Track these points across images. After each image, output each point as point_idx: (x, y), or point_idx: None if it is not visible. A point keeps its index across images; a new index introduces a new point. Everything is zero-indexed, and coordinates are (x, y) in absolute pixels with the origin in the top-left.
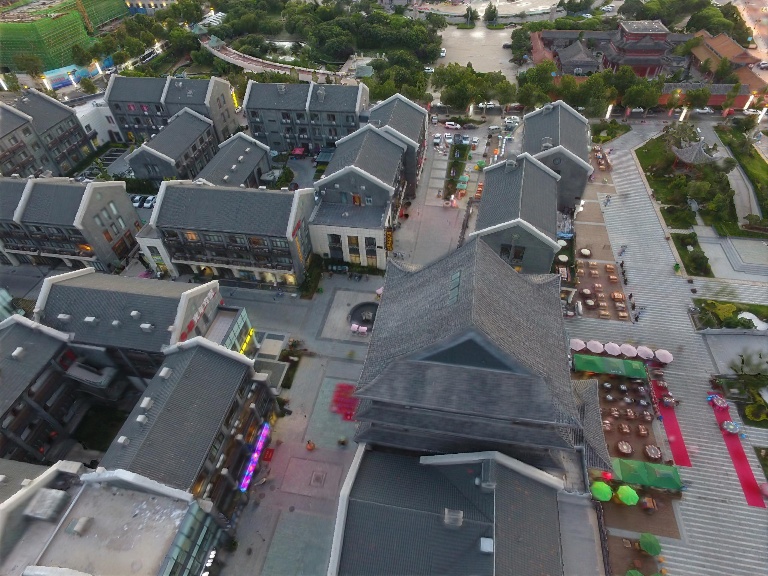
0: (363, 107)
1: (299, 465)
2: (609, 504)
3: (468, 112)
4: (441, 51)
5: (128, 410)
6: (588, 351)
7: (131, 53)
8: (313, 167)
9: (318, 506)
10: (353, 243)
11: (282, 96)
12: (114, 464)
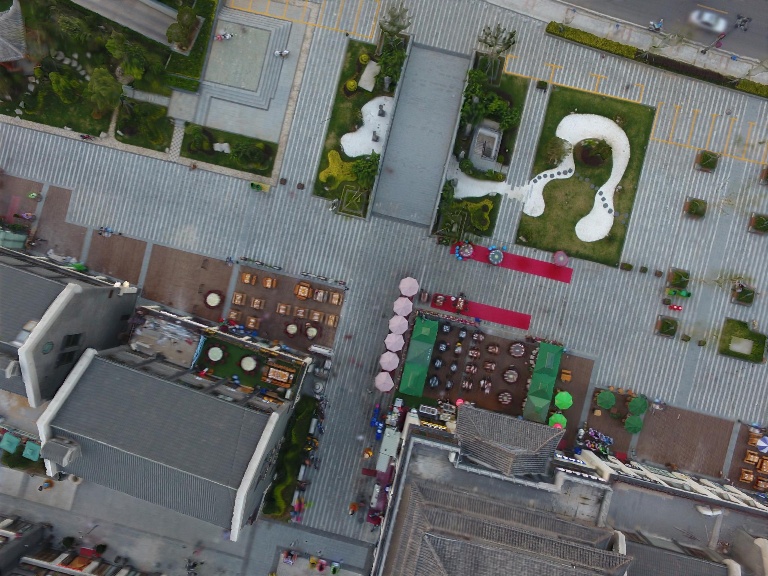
0: None
1: None
2: None
3: None
4: None
5: None
6: None
7: None
8: None
9: None
10: None
11: None
12: None
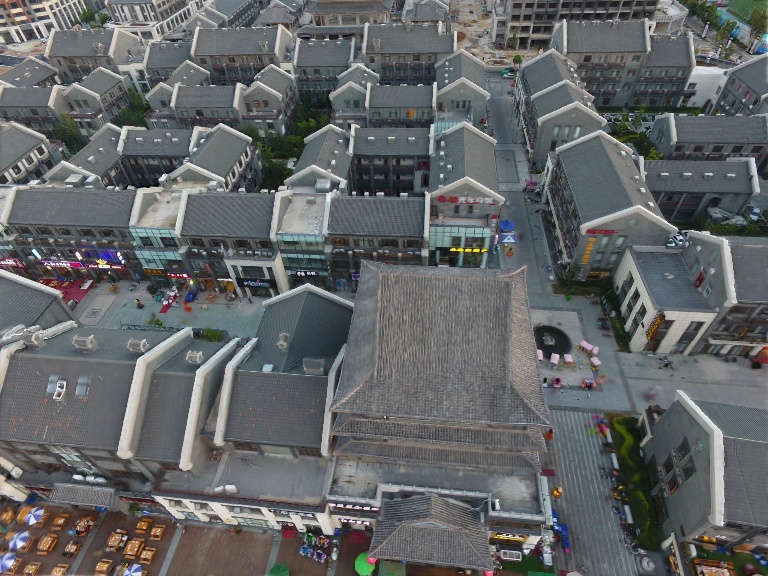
0: None
1: None
2: None
3: None
4: None
5: None
6: None
7: None
8: None
9: None
10: (636, 299)
11: None
12: None
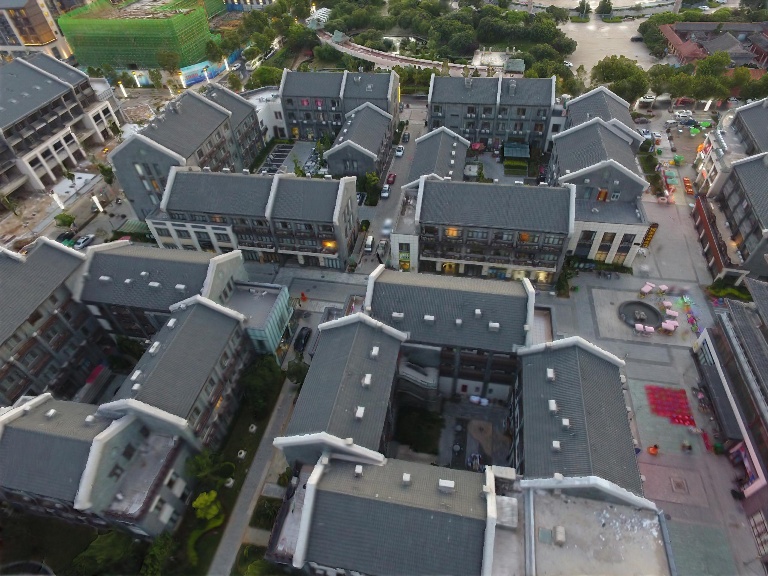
0: None
1: (651, 471)
2: None
3: (633, 106)
4: (576, 44)
5: (438, 411)
6: None
7: None
8: (497, 162)
9: (695, 514)
10: (606, 240)
11: (468, 90)
12: (559, 470)
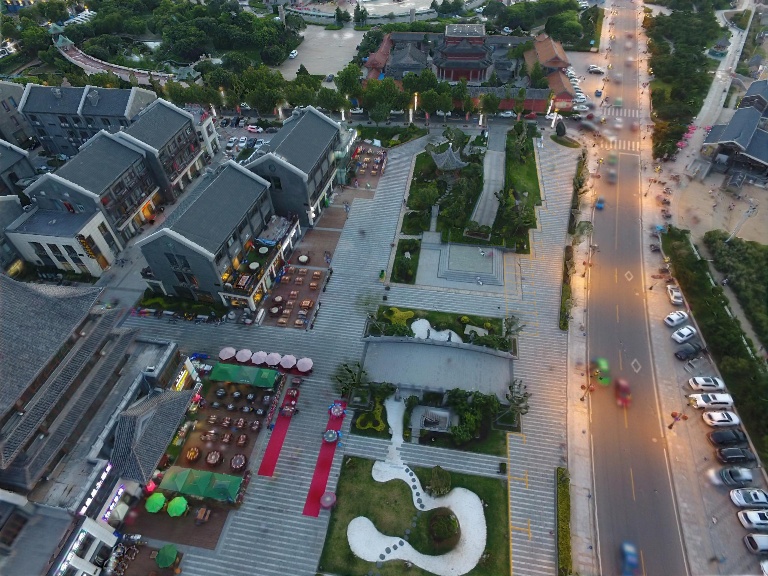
0: None
1: None
2: (166, 515)
3: (278, 115)
4: (284, 53)
5: None
6: (236, 360)
7: None
8: None
9: None
10: (57, 251)
11: (58, 100)
12: None
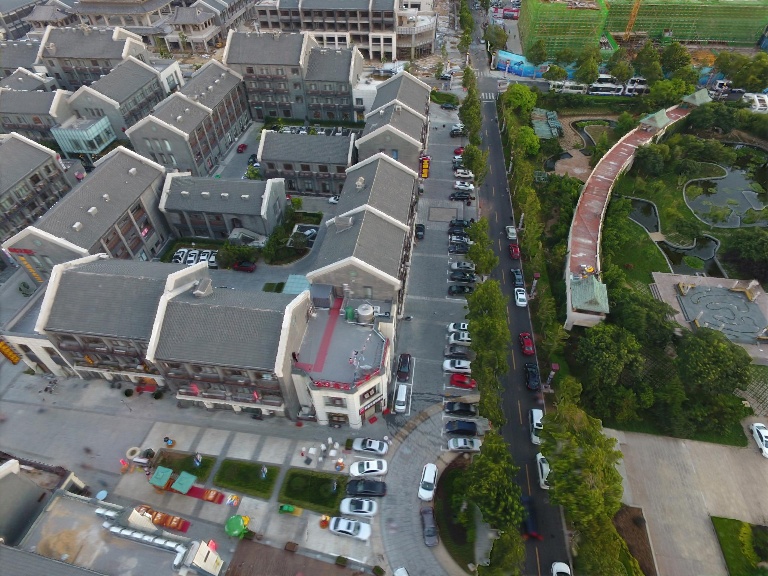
0: (344, 286)
1: None
2: None
3: None
4: None
5: None
6: None
7: (575, 75)
8: None
9: None
10: None
11: (356, 192)
12: None
